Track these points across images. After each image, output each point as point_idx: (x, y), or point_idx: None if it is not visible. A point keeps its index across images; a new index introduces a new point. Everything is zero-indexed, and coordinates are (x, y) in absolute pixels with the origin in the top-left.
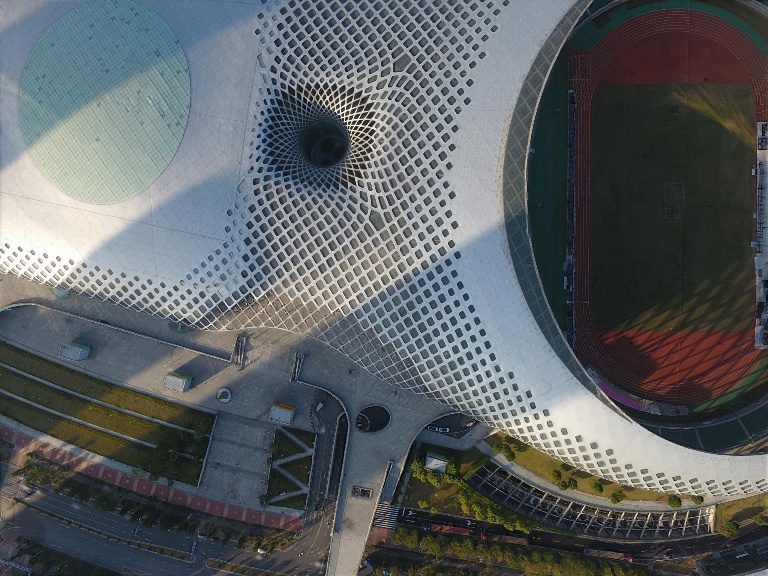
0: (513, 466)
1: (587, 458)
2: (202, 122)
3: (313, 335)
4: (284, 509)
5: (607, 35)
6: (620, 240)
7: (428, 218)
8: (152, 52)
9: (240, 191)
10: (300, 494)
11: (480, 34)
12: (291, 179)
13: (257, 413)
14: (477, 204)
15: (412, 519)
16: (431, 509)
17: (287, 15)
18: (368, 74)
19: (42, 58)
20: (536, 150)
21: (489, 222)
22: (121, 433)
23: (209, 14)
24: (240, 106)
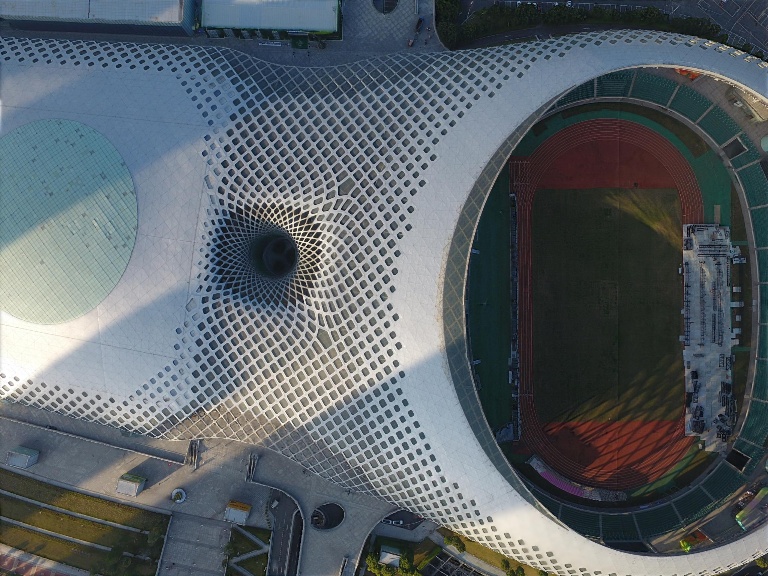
0: (464, 555)
1: (530, 558)
2: (149, 243)
3: (265, 445)
4: None
5: (544, 142)
6: (560, 336)
7: (373, 338)
8: (97, 175)
9: (189, 310)
10: None
11: (420, 162)
12: (240, 297)
13: (212, 512)
14: (419, 327)
15: None
16: None
17: (234, 137)
18: (314, 196)
19: None
20: (480, 251)
21: (431, 345)
22: (72, 536)
23: (156, 135)
24: (188, 227)
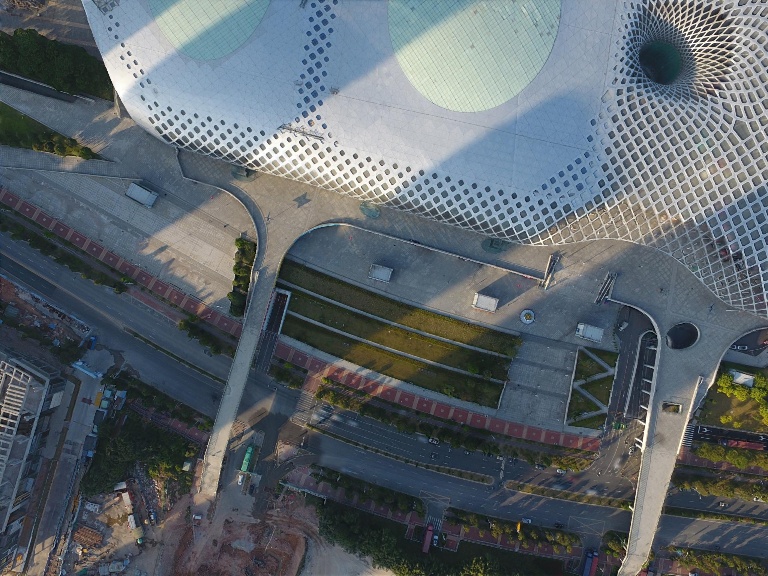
0: None
1: None
2: (570, 33)
3: None
4: (582, 429)
5: None
6: None
7: None
8: None
9: (604, 101)
10: (600, 414)
11: None
12: (651, 91)
13: (560, 334)
14: None
15: (707, 436)
16: (735, 423)
17: None
18: None
19: None
20: None
21: None
22: (420, 356)
23: None
24: (606, 19)
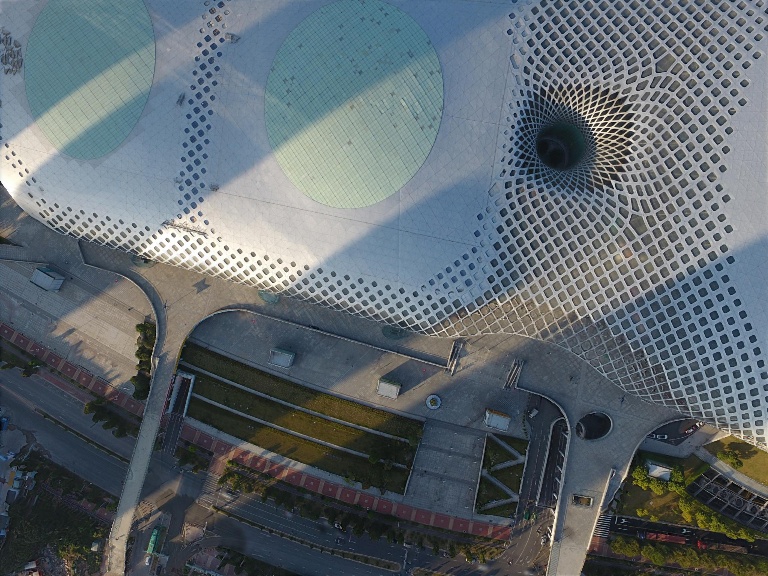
0: (734, 473)
1: None
2: (454, 124)
3: (554, 341)
4: (492, 517)
5: None
6: None
7: (697, 222)
8: (405, 53)
9: (491, 195)
10: (510, 502)
11: (752, 33)
12: (543, 182)
13: (467, 420)
14: (756, 208)
15: (625, 527)
16: (651, 517)
17: (539, 15)
18: (627, 75)
19: (290, 60)
20: None
21: None
22: (324, 440)
23: (459, 14)
24: (493, 108)
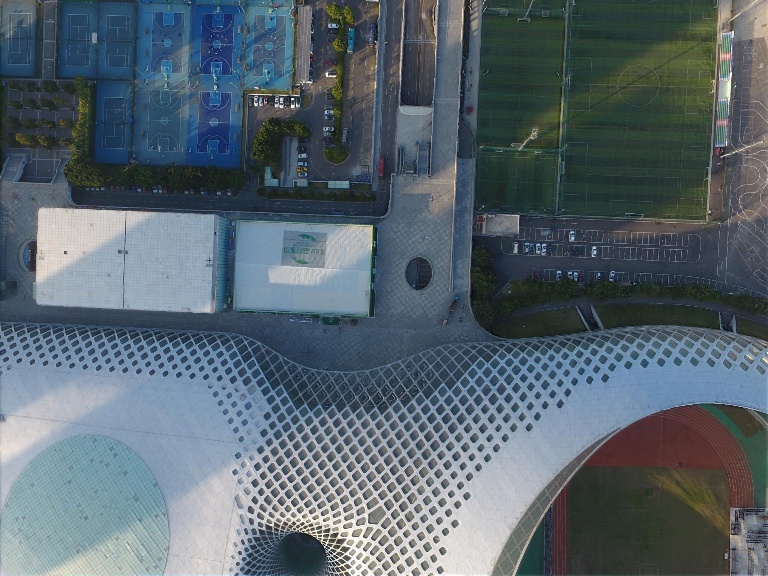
0: None
1: None
2: (180, 563)
3: None
4: None
5: None
6: None
7: None
8: (130, 497)
9: None
10: None
11: (453, 499)
12: None
13: None
14: None
15: None
16: None
17: (264, 454)
18: (344, 520)
19: (22, 498)
20: None
21: None
22: None
23: (187, 453)
24: (218, 547)
